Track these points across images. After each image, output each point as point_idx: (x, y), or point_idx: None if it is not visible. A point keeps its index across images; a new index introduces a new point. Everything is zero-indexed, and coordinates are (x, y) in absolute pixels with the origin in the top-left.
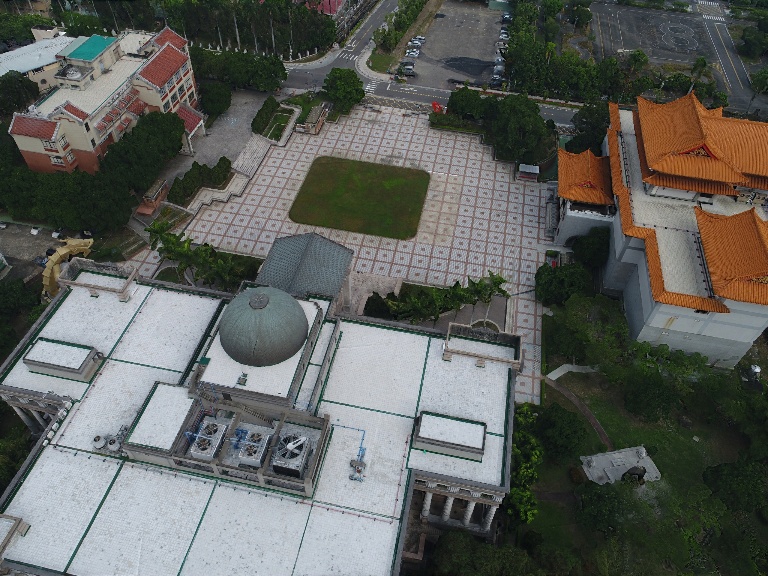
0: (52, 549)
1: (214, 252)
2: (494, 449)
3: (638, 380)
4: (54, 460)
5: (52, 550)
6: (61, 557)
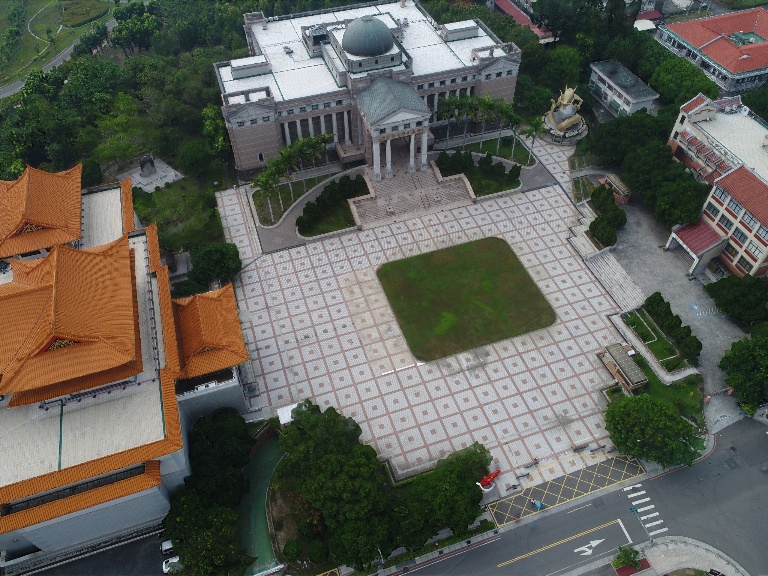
0: (387, 7)
1: (511, 173)
2: (226, 76)
3: (143, 196)
4: (418, 18)
5: (386, 7)
6: (381, 7)
